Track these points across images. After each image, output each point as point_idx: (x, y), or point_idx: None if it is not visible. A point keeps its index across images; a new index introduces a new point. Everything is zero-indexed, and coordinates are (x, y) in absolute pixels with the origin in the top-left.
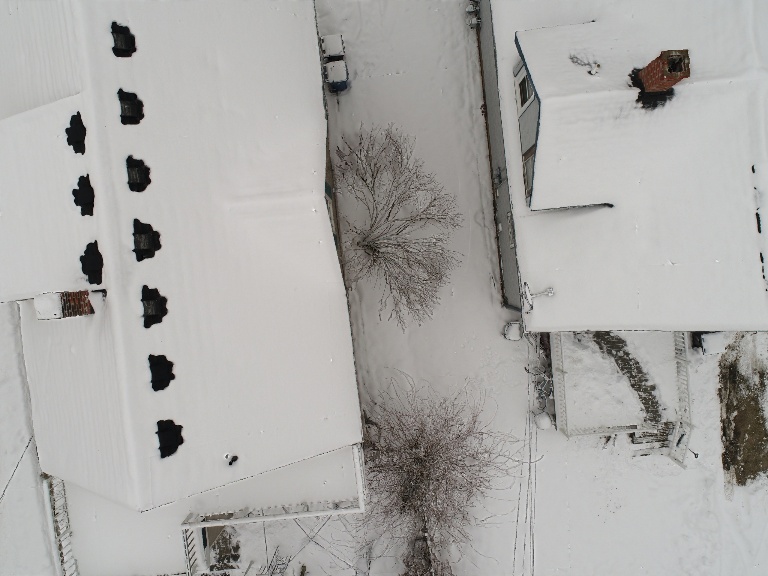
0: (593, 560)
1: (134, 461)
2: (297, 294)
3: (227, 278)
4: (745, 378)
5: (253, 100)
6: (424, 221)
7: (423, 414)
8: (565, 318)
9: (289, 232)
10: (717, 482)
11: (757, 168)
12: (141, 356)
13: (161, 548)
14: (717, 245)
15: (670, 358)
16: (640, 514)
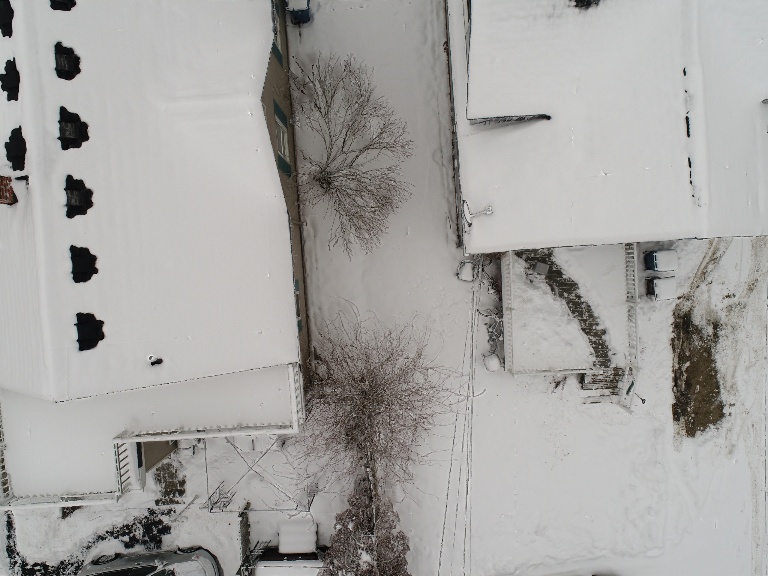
0: (539, 507)
1: (49, 350)
2: (234, 204)
3: (159, 179)
4: (699, 329)
5: (195, 3)
6: (377, 152)
7: (369, 346)
8: (502, 237)
9: (226, 138)
10: (666, 433)
11: (688, 70)
12: (62, 245)
13: (95, 465)
14: (648, 152)
15: (621, 302)
16: (588, 462)
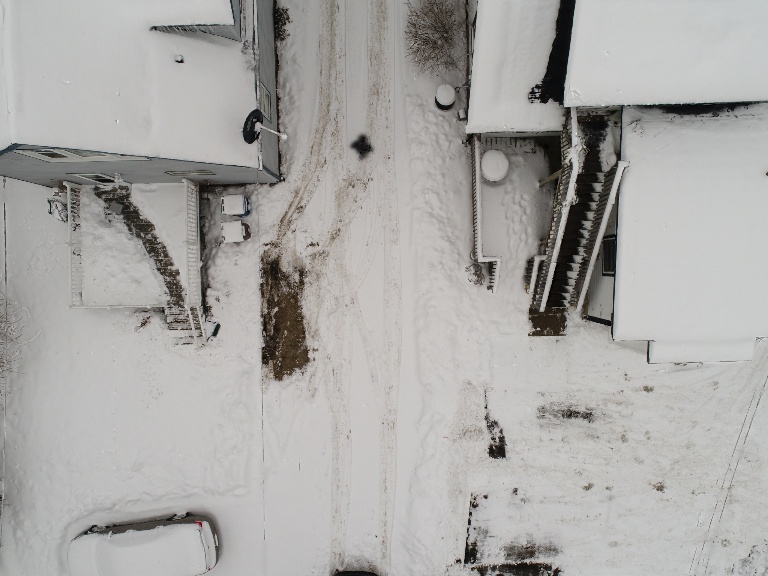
0: (137, 445)
1: None
2: None
3: None
4: (286, 275)
5: None
6: None
7: None
8: None
9: None
10: (255, 375)
11: None
12: None
13: None
14: None
15: None
16: (183, 402)
